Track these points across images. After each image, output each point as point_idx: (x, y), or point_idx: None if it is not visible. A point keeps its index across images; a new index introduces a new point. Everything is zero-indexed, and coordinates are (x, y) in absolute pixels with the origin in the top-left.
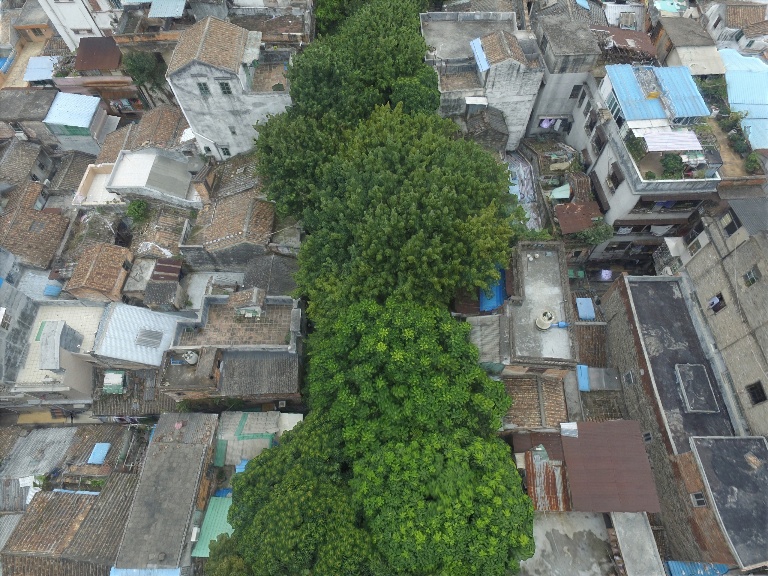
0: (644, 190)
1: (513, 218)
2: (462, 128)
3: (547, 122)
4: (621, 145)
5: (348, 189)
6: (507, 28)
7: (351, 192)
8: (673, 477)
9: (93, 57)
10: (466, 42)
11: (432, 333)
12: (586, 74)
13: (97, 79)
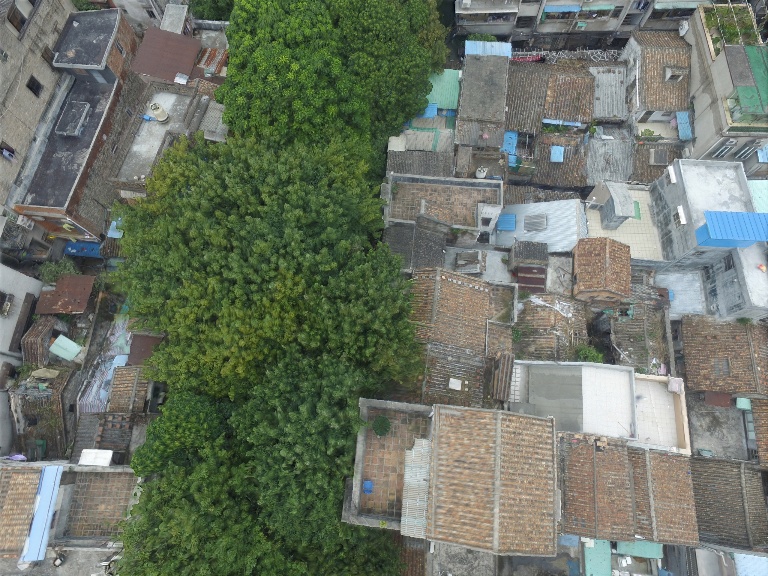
0: None
1: None
2: (139, 437)
3: None
4: None
5: None
6: None
7: None
8: (128, 76)
9: None
10: None
11: None
12: None
13: None
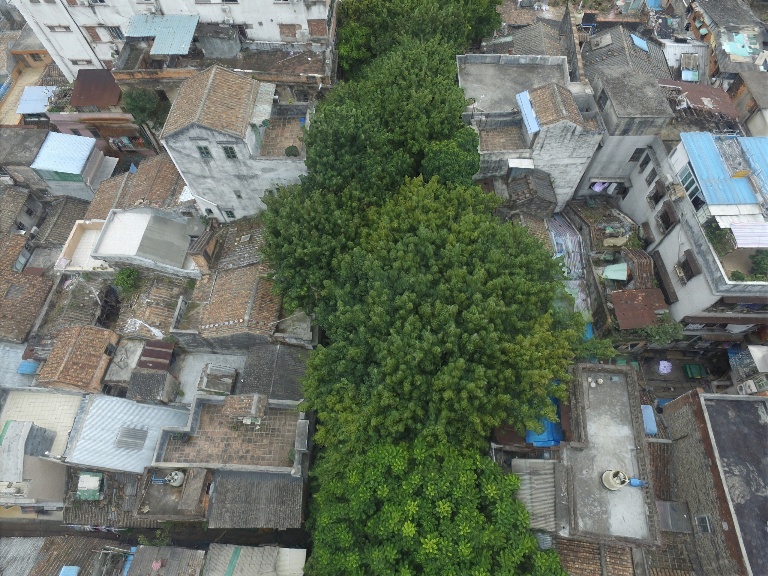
0: (728, 291)
1: (572, 333)
2: (502, 193)
3: (599, 185)
4: (698, 231)
5: (371, 295)
6: (556, 75)
7: (375, 298)
8: None
9: (91, 92)
10: (509, 90)
11: (472, 494)
12: (652, 137)
13: (95, 115)
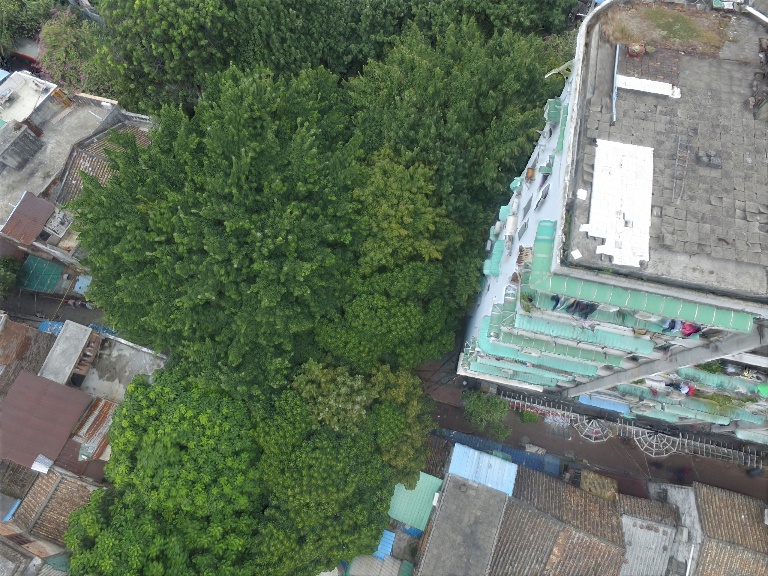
0: None
1: None
2: None
3: None
4: None
5: None
6: None
7: None
8: (5, 393)
9: None
10: None
11: None
12: None
13: None
